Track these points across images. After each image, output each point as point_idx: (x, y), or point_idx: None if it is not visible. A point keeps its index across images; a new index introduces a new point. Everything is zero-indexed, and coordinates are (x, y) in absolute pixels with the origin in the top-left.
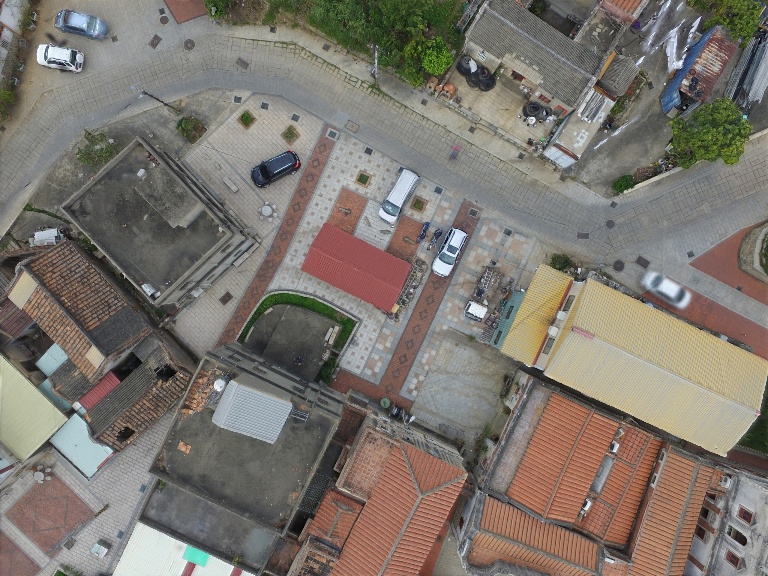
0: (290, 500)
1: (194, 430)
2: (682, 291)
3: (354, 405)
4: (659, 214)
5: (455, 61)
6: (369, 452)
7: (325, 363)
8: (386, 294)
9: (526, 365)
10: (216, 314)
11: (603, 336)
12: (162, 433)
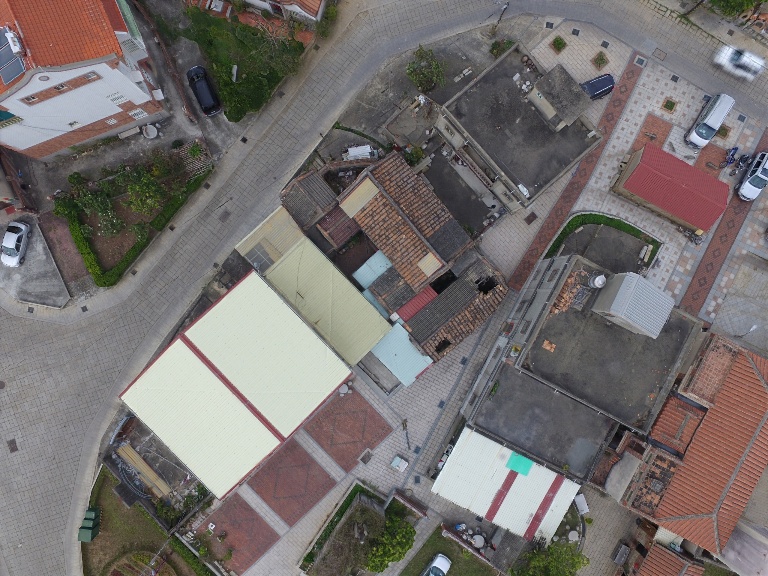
0: (648, 401)
1: (559, 329)
2: None
3: None
4: None
5: None
6: (712, 360)
7: None
8: (709, 212)
9: None
10: (520, 233)
11: None
12: (463, 349)
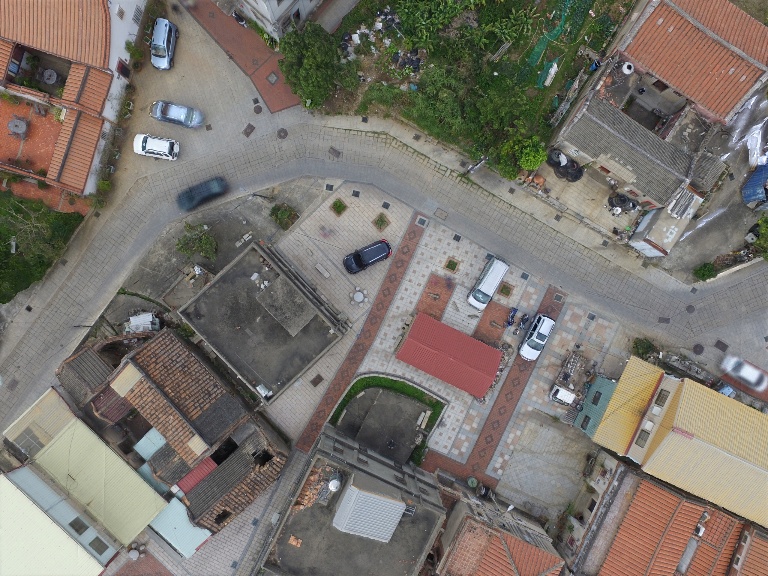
0: None
1: (305, 524)
2: (759, 374)
3: (447, 488)
4: (738, 300)
5: None
6: (469, 541)
7: (416, 446)
8: (479, 382)
9: (617, 453)
10: (307, 396)
11: (702, 436)
12: (254, 511)
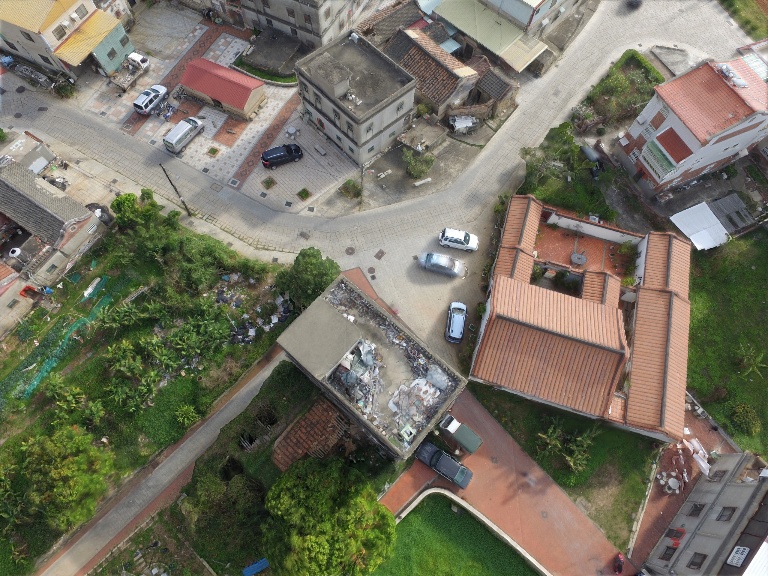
0: None
1: None
2: None
3: (236, 9)
4: None
5: (114, 222)
6: None
7: None
8: (201, 63)
9: None
10: None
11: None
12: None
